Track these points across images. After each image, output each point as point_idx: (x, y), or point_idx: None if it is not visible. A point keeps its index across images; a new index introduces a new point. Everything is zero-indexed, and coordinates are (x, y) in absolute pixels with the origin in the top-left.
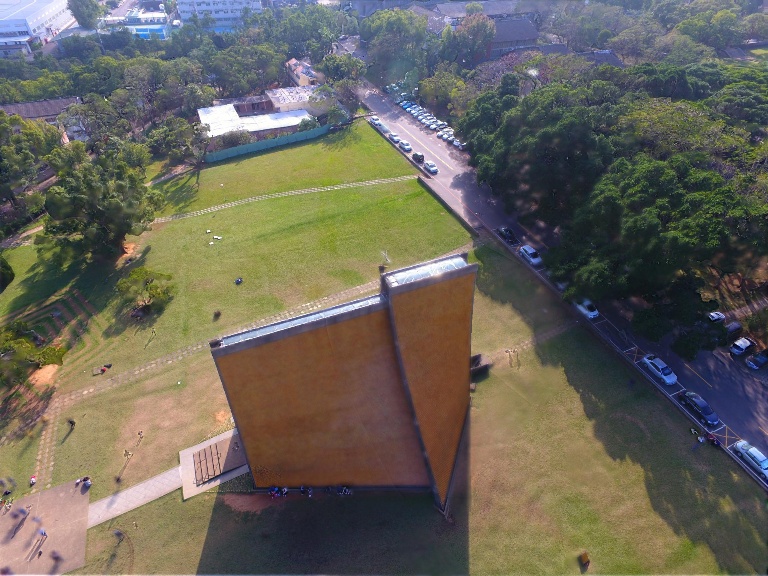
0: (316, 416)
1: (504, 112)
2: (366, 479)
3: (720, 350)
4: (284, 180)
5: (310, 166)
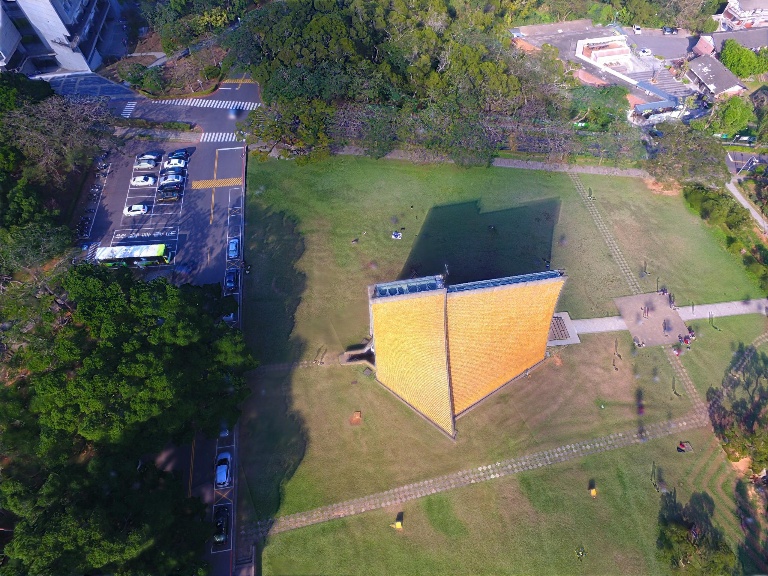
0: None
1: None
2: None
3: None
4: None
5: None
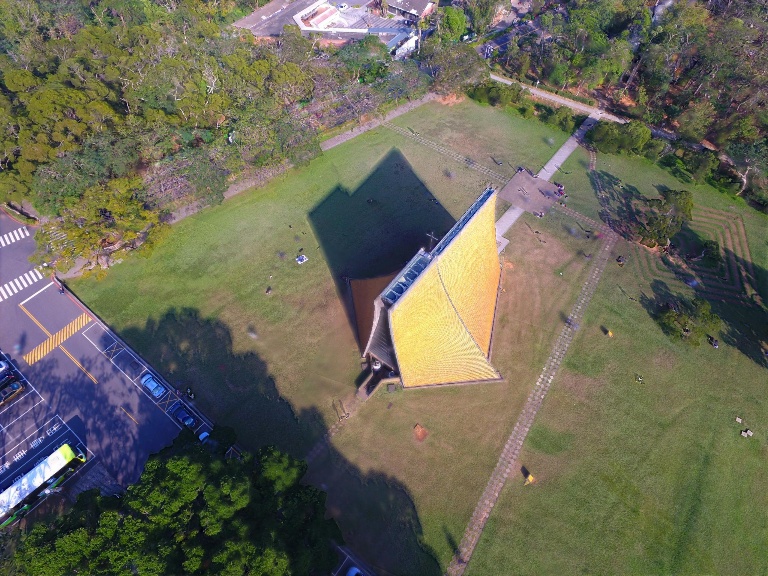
0: None
1: None
2: None
3: None
4: None
5: None
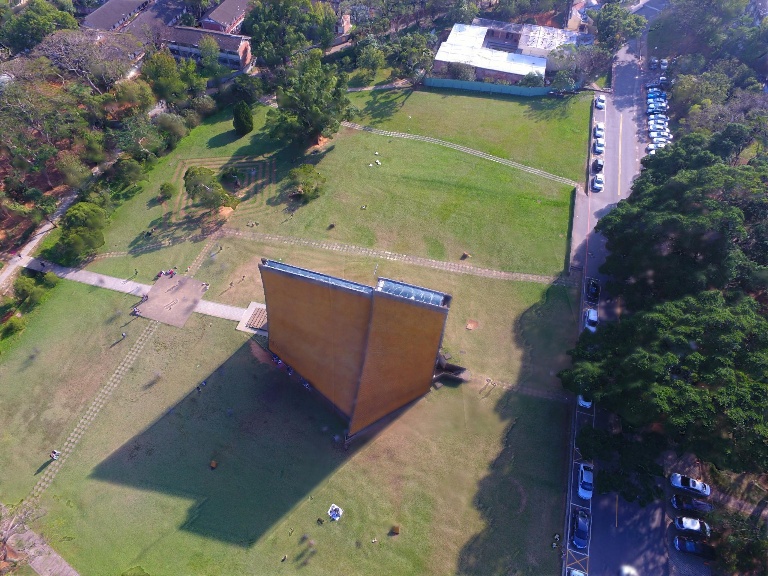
0: (310, 334)
1: (681, 170)
2: (322, 389)
3: (667, 512)
4: (465, 132)
5: (498, 127)
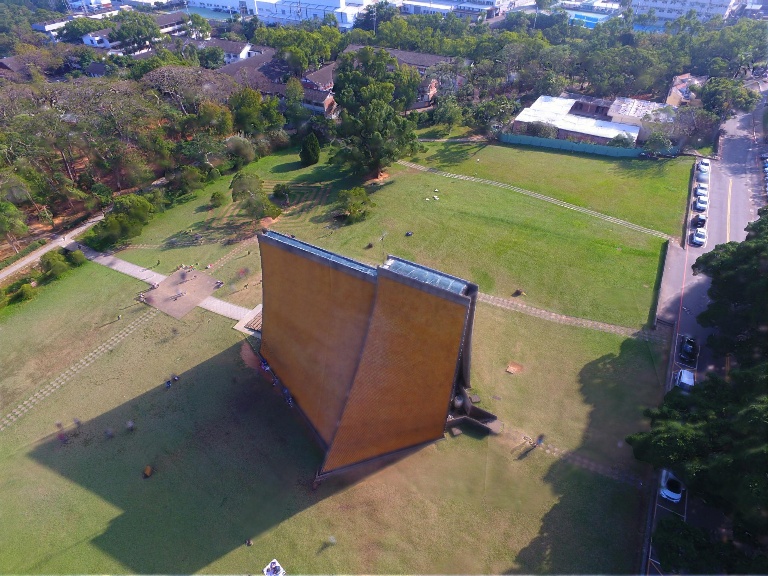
0: (303, 333)
1: None
2: (306, 406)
3: None
4: (538, 180)
5: (576, 179)
